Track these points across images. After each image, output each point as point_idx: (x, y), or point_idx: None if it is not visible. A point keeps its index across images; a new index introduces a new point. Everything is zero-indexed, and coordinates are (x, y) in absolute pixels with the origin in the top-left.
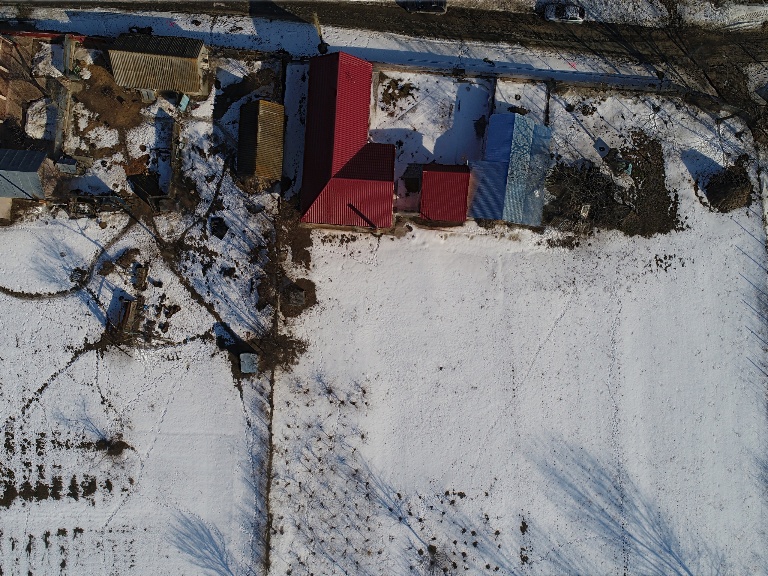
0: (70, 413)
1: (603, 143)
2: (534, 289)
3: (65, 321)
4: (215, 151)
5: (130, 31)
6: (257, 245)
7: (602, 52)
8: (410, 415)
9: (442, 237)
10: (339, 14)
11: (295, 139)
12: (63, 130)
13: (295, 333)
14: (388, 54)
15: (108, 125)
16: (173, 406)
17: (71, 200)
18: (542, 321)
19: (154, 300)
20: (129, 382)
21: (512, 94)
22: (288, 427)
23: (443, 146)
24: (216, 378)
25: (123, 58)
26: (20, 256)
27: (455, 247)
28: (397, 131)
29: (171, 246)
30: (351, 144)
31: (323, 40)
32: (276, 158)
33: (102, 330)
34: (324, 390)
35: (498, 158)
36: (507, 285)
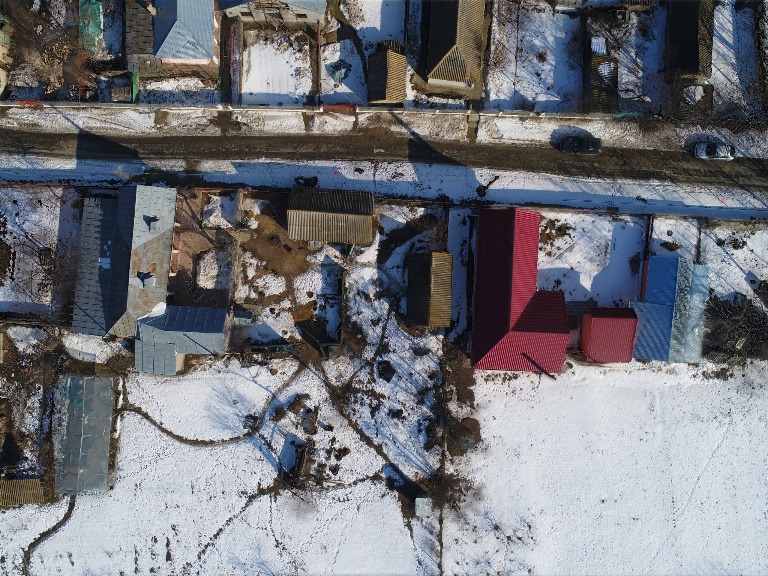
0: (245, 557)
1: (754, 276)
2: (691, 421)
3: (239, 467)
4: (380, 296)
5: (296, 181)
6: (424, 387)
7: (750, 187)
8: (574, 548)
9: (601, 373)
10: (495, 156)
11: (457, 282)
12: (233, 280)
13: (461, 471)
14: (544, 195)
15: (276, 273)
16: (345, 547)
17: (245, 351)
18: (700, 452)
19: (325, 444)
20: (302, 525)
21: (664, 230)
22: (457, 564)
23: (600, 284)
24: (386, 518)
25: (300, 216)
26: (194, 405)
27: (614, 382)
28: (555, 270)
29: (340, 390)
30: (524, 295)
31: (481, 183)
32: (446, 306)
33: (275, 475)
34: (491, 526)
35: (661, 300)
36: (665, 418)
